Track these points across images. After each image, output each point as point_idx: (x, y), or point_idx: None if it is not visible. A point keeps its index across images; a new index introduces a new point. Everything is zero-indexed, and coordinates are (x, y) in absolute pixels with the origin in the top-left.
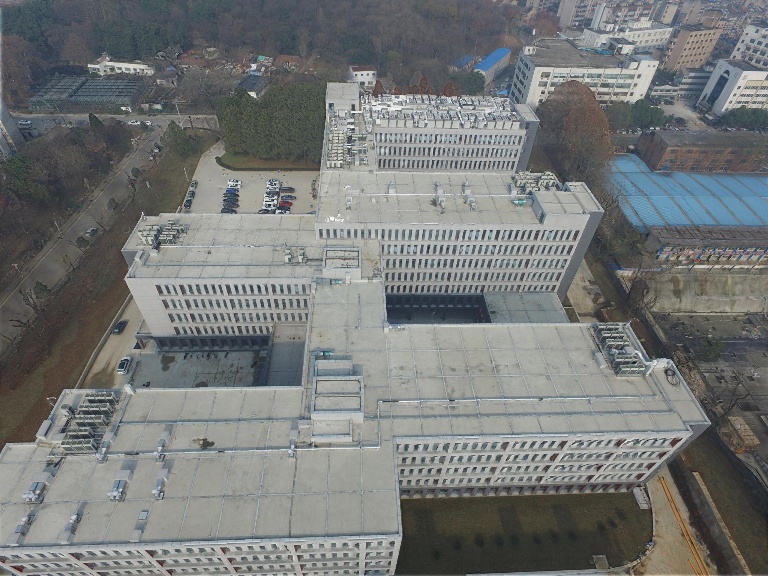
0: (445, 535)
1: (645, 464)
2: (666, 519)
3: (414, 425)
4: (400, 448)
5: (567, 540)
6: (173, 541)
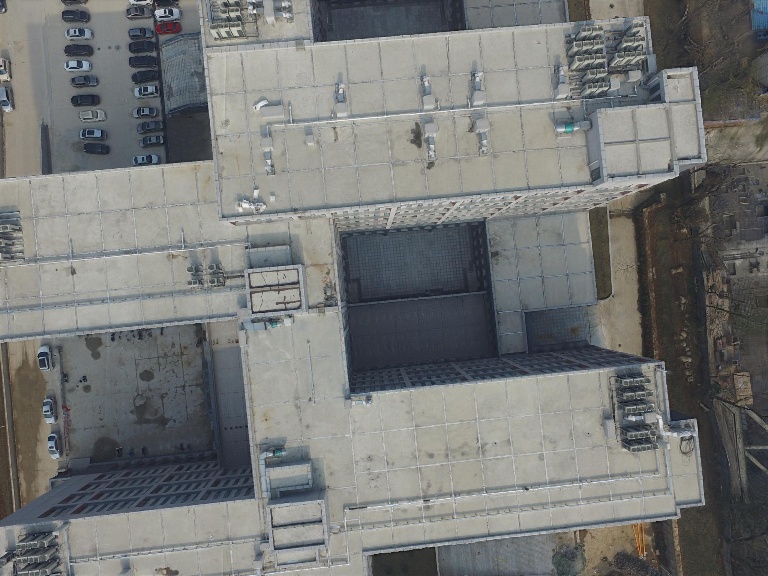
0: None
1: None
2: None
3: (384, 534)
4: None
5: None
6: None
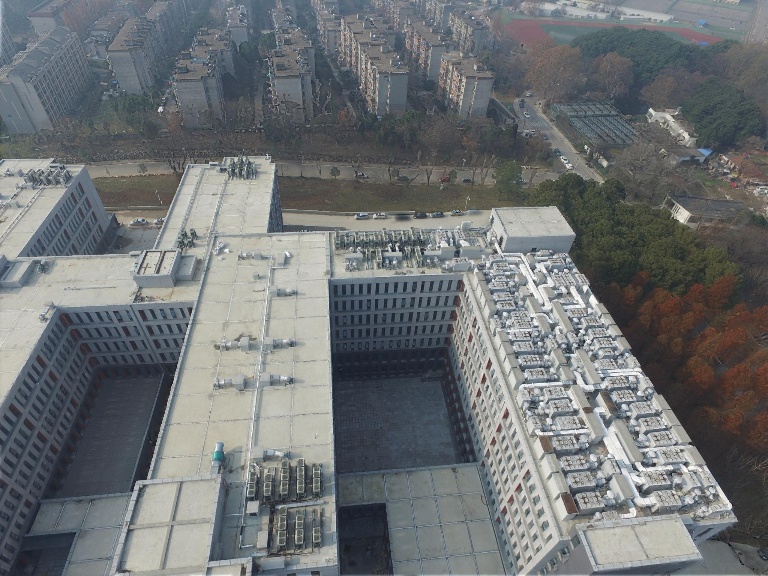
0: None
1: None
2: None
3: None
4: None
5: None
6: None
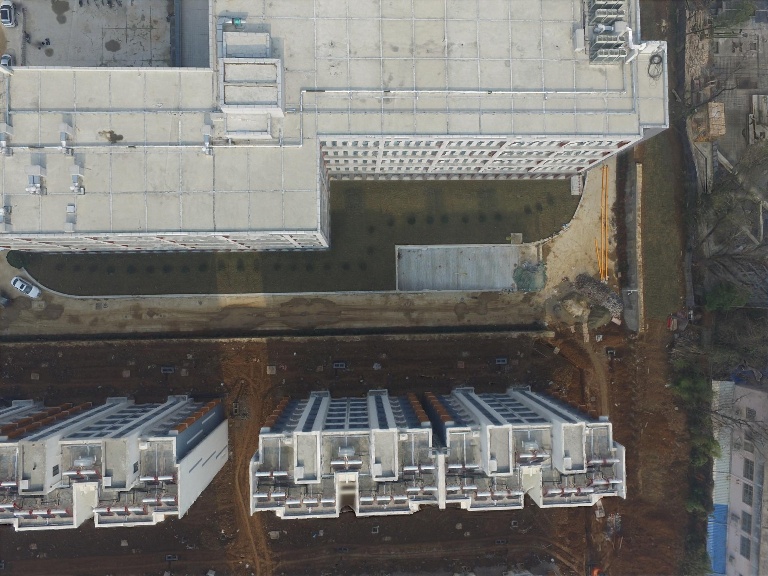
0: (381, 213)
1: (587, 159)
2: (591, 204)
3: (341, 121)
4: (328, 143)
5: (492, 220)
6: (106, 232)
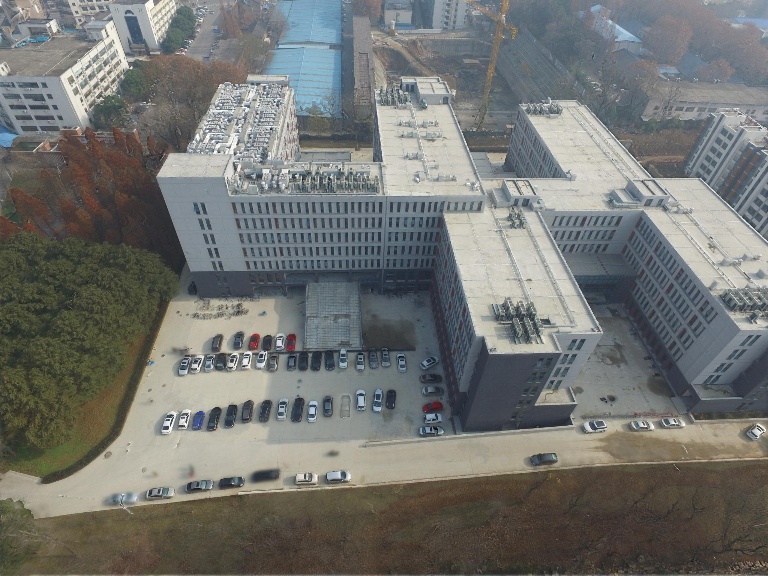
0: None
1: None
2: None
3: (638, 173)
4: None
5: None
6: None
